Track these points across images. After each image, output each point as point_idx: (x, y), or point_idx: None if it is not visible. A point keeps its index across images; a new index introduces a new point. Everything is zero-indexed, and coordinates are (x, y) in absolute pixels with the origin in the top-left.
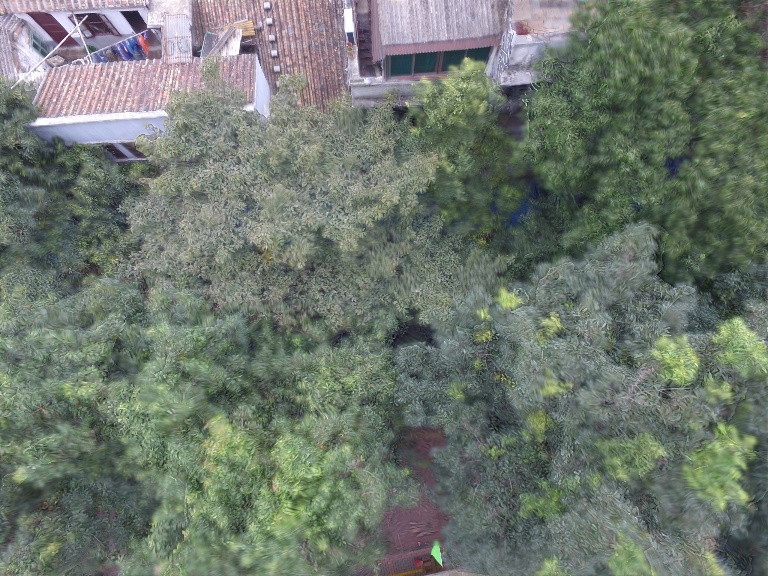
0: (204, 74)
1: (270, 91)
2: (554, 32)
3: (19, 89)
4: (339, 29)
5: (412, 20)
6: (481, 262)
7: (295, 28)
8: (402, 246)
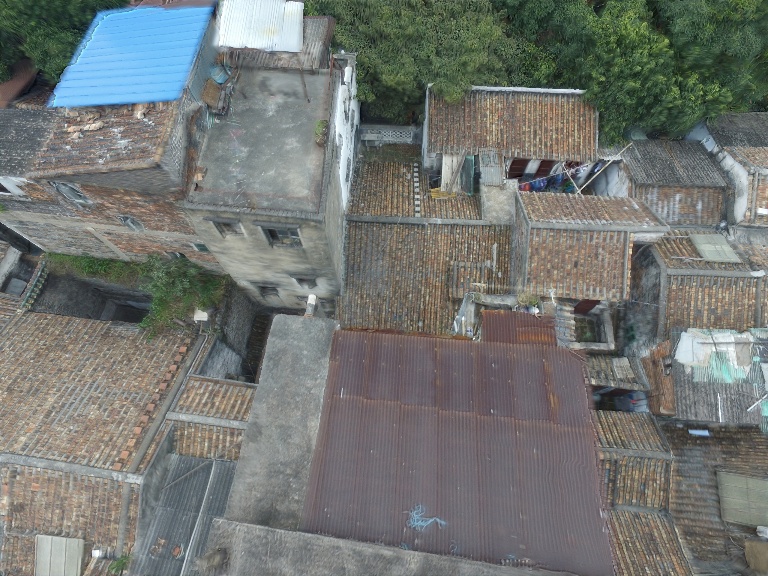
0: None
1: None
2: None
3: None
4: None
5: (305, 27)
6: None
7: None
8: None
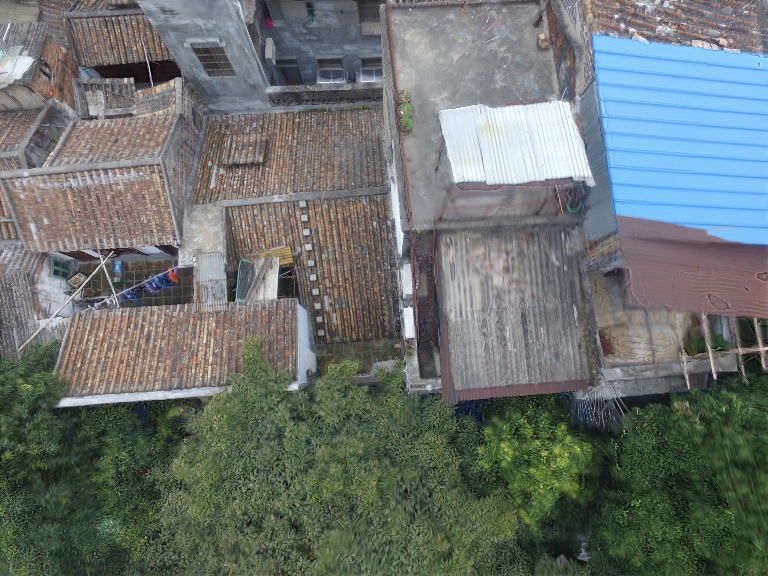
0: (245, 358)
1: (308, 315)
2: (646, 365)
3: (40, 356)
4: (383, 252)
5: (488, 360)
6: (552, 571)
7: (336, 252)
8: (469, 575)
